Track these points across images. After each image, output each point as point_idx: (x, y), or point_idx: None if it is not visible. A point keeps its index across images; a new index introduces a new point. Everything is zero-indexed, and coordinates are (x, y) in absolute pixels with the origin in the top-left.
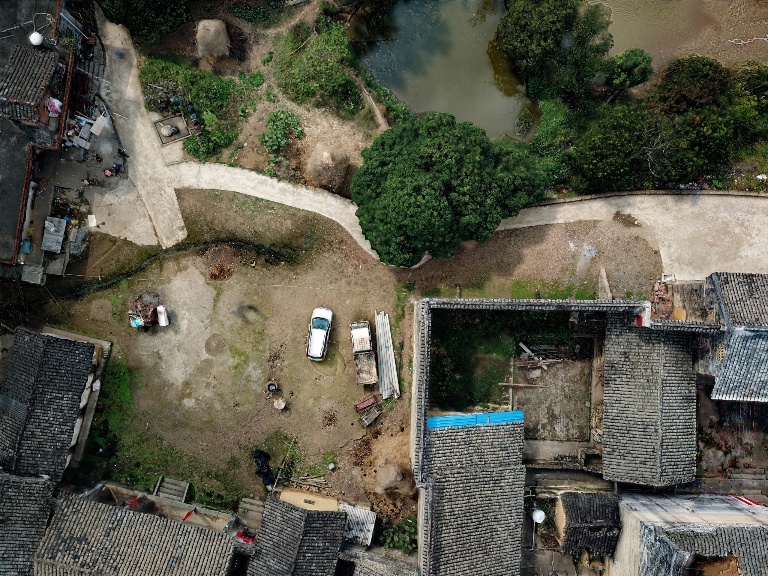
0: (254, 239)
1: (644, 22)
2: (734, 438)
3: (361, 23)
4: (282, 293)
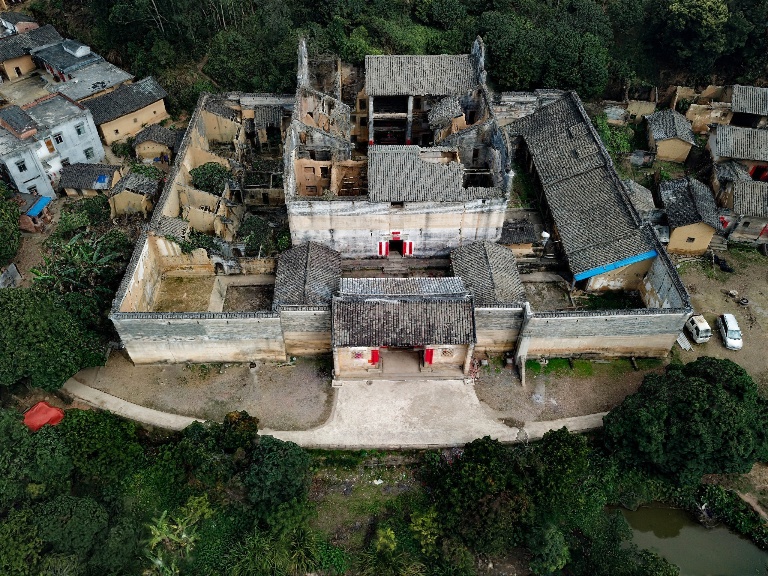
0: None
1: None
2: None
3: None
4: None
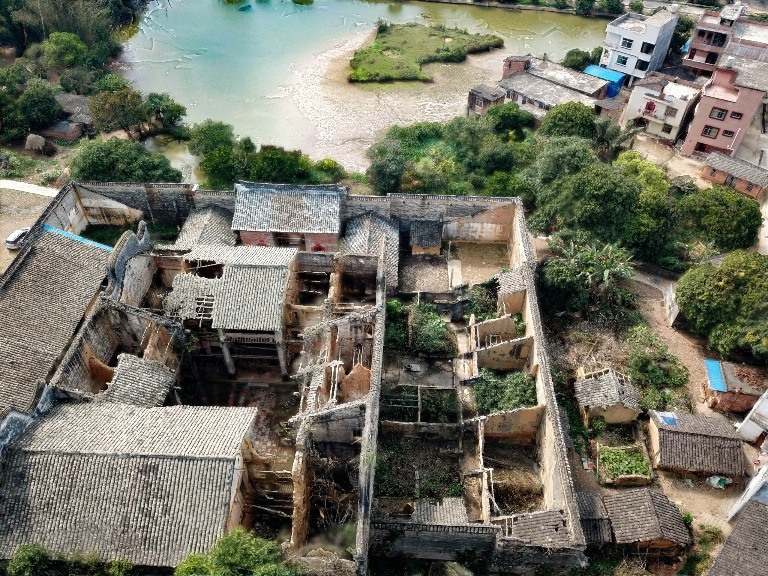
0: (9, 205)
1: None
2: None
3: None
4: (11, 225)
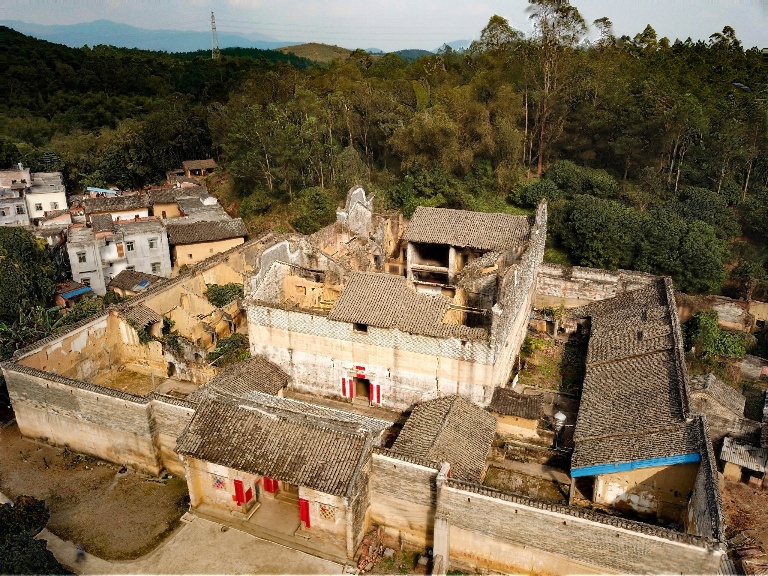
0: None
1: None
2: None
3: None
4: None
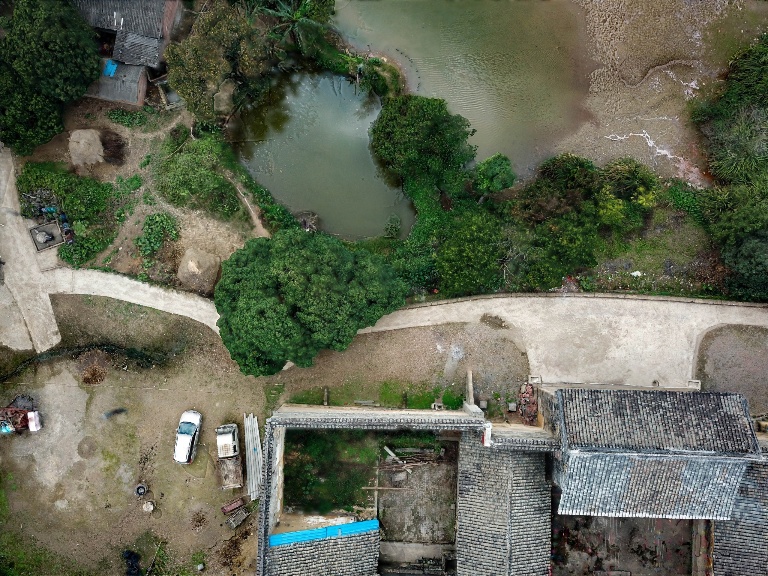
0: (126, 343)
1: (520, 119)
2: (600, 540)
3: (239, 124)
4: (153, 396)
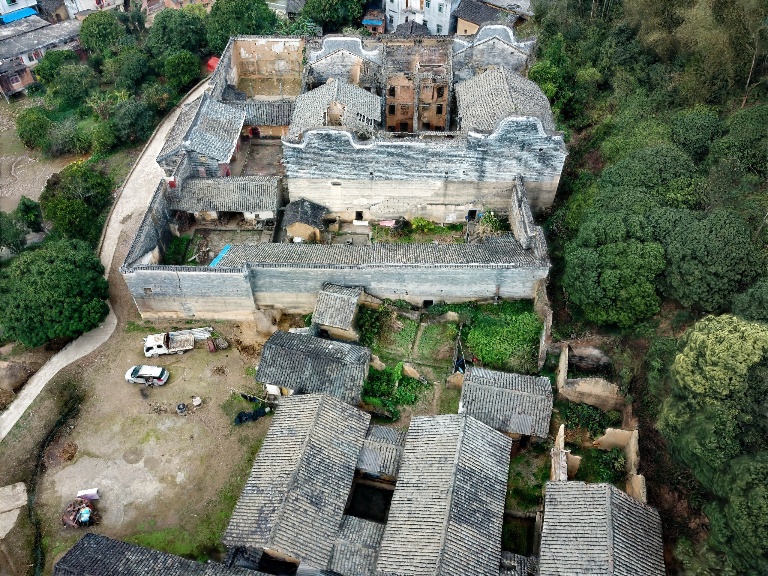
0: (50, 427)
1: None
2: None
3: None
4: (105, 405)
